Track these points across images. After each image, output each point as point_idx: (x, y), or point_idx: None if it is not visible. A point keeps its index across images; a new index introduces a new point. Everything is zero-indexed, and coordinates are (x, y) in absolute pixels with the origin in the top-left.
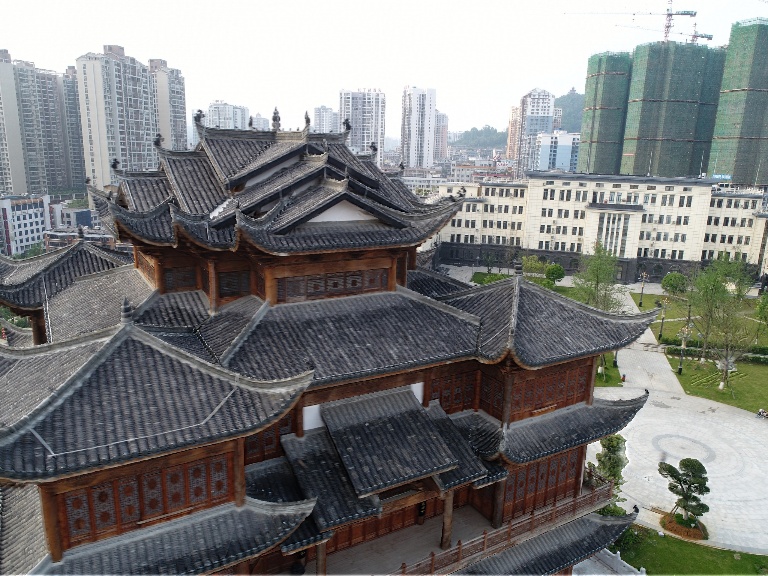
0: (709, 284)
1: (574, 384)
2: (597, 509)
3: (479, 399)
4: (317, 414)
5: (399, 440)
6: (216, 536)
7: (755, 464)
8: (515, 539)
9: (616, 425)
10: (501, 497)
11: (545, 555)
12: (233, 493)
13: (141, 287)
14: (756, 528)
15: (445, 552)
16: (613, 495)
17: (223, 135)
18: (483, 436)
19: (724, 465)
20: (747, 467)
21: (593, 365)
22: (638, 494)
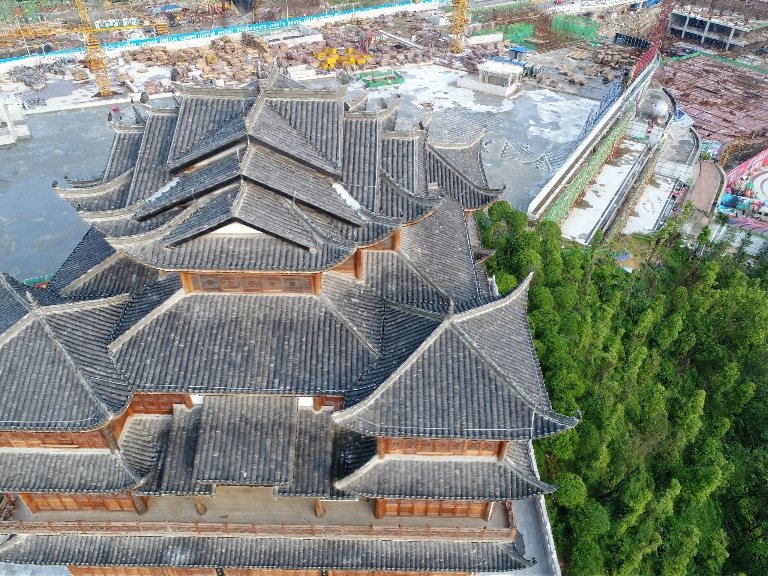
0: None
1: None
2: None
3: None
4: None
5: None
6: None
7: None
8: None
9: None
10: None
11: None
12: None
13: None
14: None
15: None
16: None
17: (321, 95)
18: None
19: None
20: None
21: None
22: None
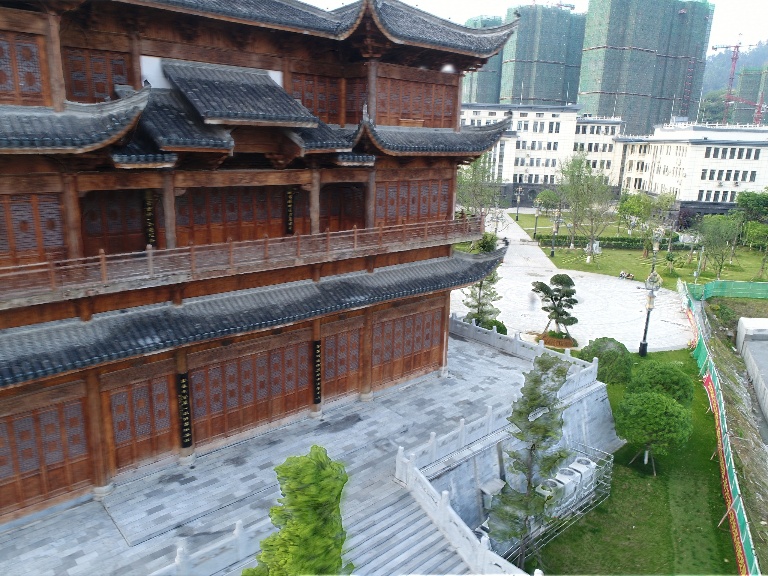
0: (575, 167)
1: (441, 104)
2: (469, 241)
3: (345, 112)
4: (158, 69)
5: (253, 97)
6: (27, 126)
7: (618, 304)
8: (387, 246)
9: (483, 145)
10: (371, 207)
11: (419, 279)
12: (50, 95)
13: None
14: (619, 338)
15: (311, 235)
16: (490, 294)
17: None
18: (349, 137)
19: (591, 305)
20: (611, 305)
21: (459, 86)
22: (515, 325)
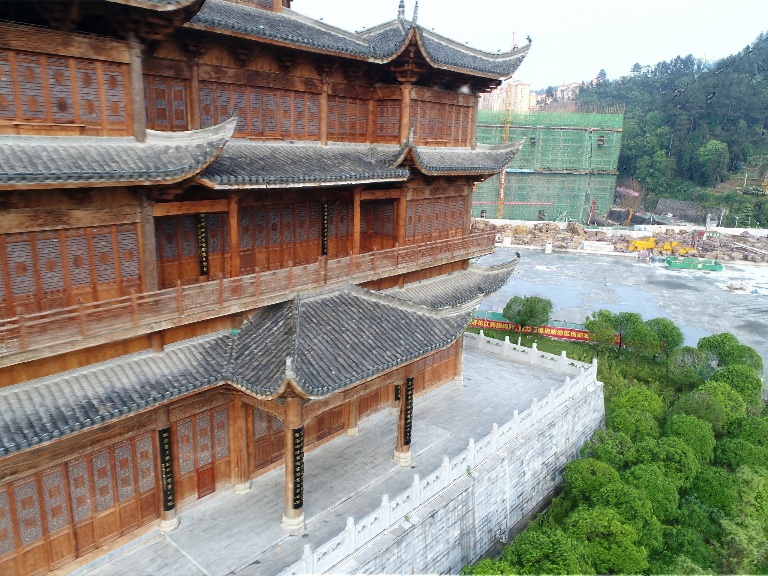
0: None
1: None
2: None
3: None
4: None
5: None
6: None
7: None
8: None
9: None
10: None
11: None
12: None
13: (240, 6)
14: None
15: None
16: None
17: None
18: None
19: None
20: None
21: None
22: None
